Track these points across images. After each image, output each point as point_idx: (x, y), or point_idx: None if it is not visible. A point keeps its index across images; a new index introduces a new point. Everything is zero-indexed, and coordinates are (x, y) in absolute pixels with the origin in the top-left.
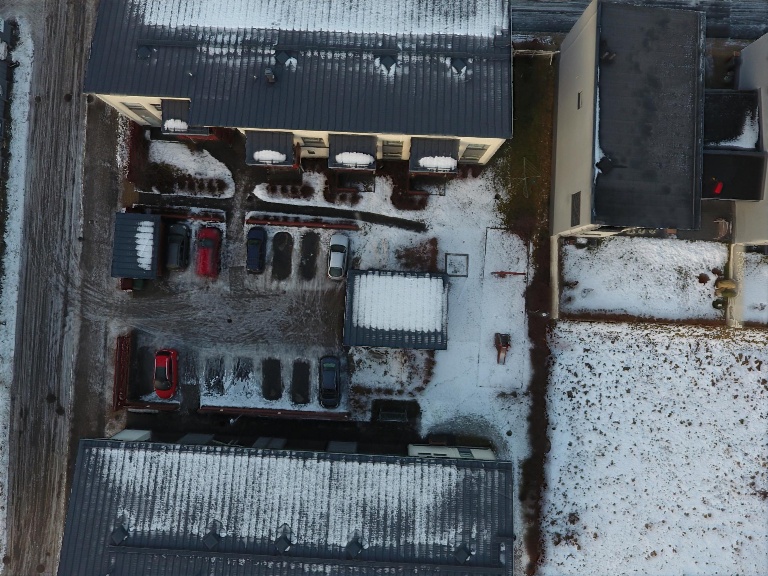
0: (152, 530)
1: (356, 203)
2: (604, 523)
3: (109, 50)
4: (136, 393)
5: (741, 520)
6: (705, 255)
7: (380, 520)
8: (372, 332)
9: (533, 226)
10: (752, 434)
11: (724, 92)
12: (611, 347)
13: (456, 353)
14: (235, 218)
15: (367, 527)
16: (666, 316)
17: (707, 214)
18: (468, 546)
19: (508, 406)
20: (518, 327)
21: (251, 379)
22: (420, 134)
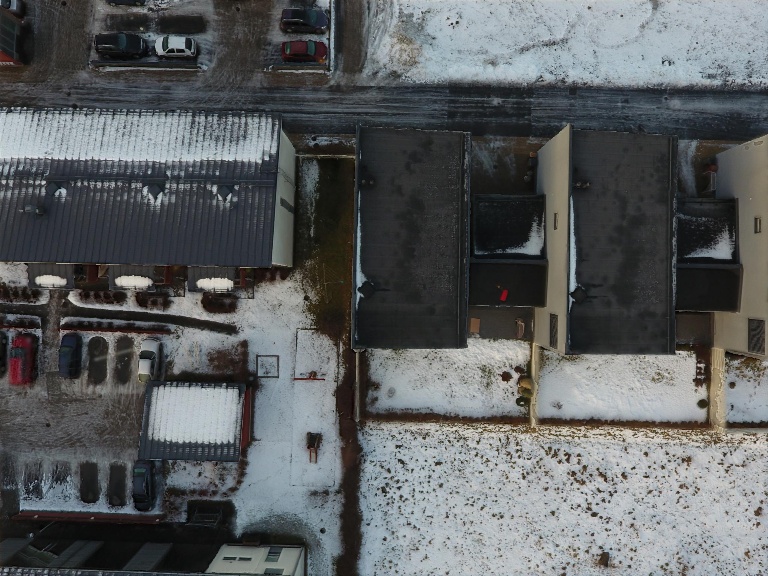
0: None
1: (168, 307)
2: None
3: None
4: None
5: None
6: (507, 353)
7: None
8: (166, 445)
9: (342, 326)
10: (563, 525)
11: (511, 198)
12: (423, 443)
13: (269, 453)
14: (51, 324)
15: None
16: (471, 414)
17: (509, 313)
18: None
19: (321, 504)
20: (329, 426)
21: (69, 482)
22: None
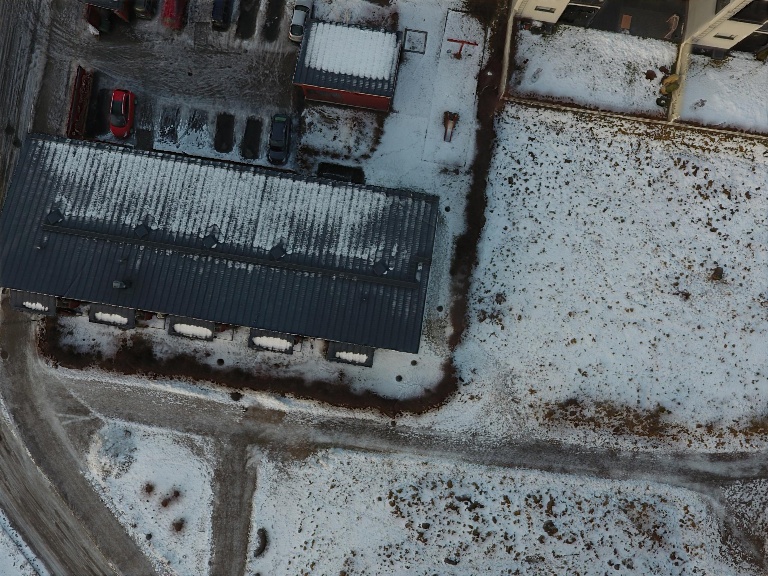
0: (87, 217)
1: None
2: (529, 307)
3: None
4: (92, 132)
5: (661, 318)
6: (655, 53)
7: (306, 231)
8: (322, 74)
9: (493, 12)
10: (681, 237)
11: None
12: (555, 139)
13: (405, 126)
14: None
15: (293, 236)
16: (610, 108)
17: (661, 14)
18: (387, 262)
19: (449, 183)
20: (468, 108)
21: (205, 131)
22: None
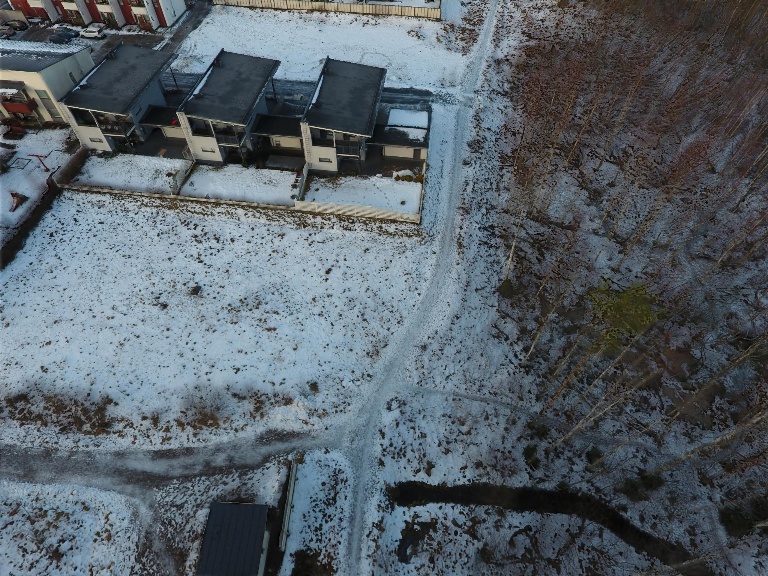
0: None
1: None
2: (21, 317)
3: None
4: None
5: (137, 323)
6: (176, 165)
7: None
8: None
9: None
10: (174, 267)
11: None
12: (97, 211)
13: None
14: None
15: None
16: None
17: None
18: None
19: None
20: (37, 194)
21: None
22: None
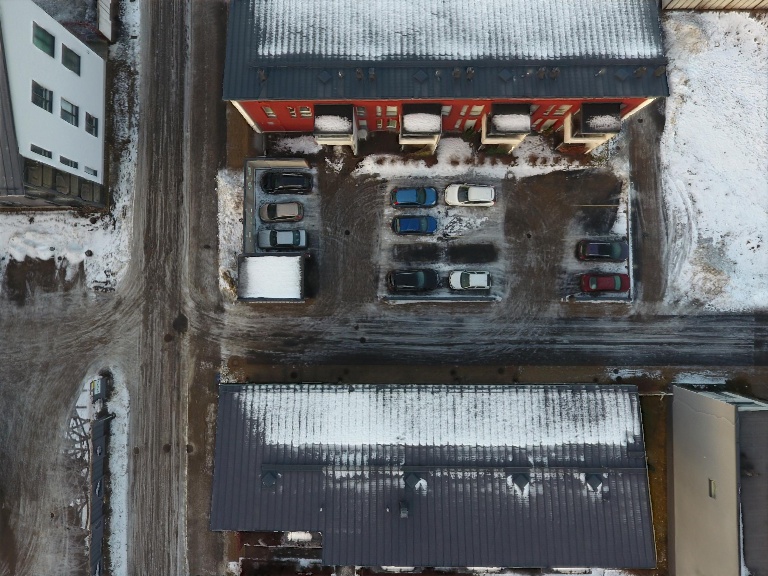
0: None
1: None
2: None
3: (232, 477)
4: None
5: None
6: None
7: None
8: None
9: None
10: None
11: None
12: None
13: None
14: (345, 568)
15: None
16: None
17: None
18: None
19: None
20: None
21: None
22: (562, 567)
